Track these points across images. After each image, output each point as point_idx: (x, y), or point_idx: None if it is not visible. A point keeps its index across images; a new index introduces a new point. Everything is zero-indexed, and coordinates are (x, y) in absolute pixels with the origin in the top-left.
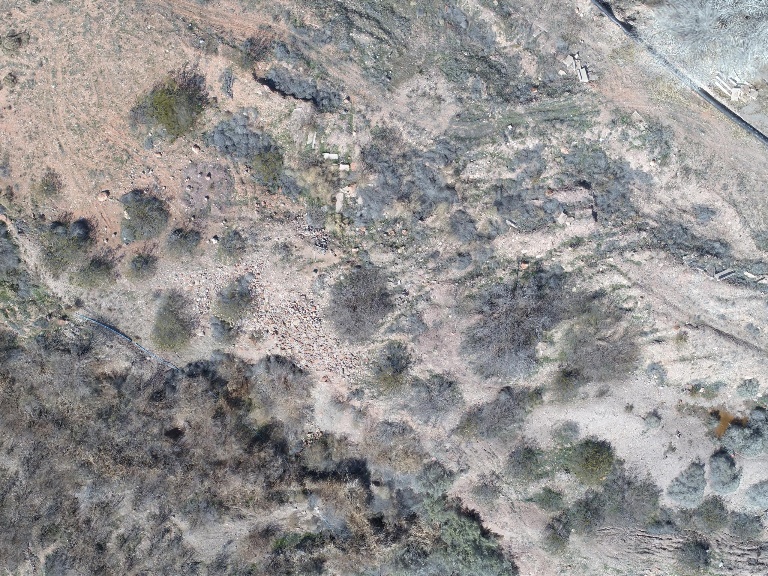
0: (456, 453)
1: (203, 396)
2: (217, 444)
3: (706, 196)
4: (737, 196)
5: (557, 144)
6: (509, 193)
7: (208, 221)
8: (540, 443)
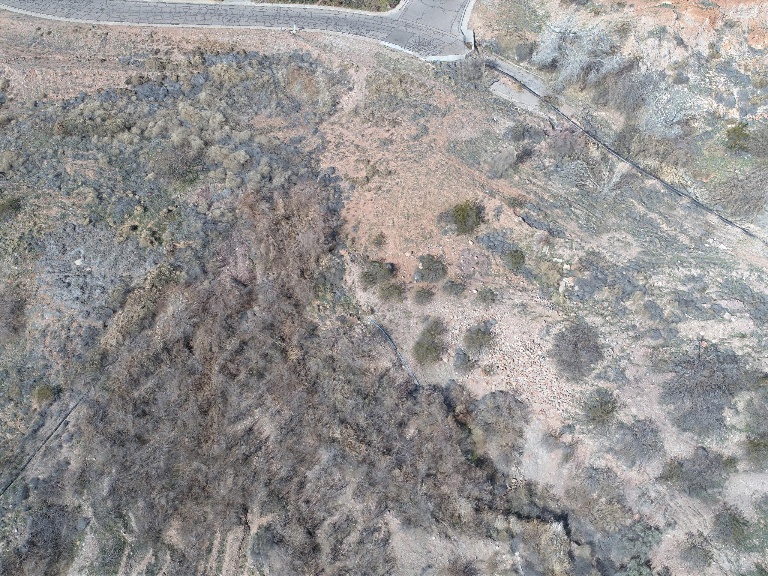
0: (661, 505)
1: (439, 405)
2: (446, 443)
3: None
4: None
5: (714, 275)
6: (684, 298)
7: (472, 281)
8: (743, 511)
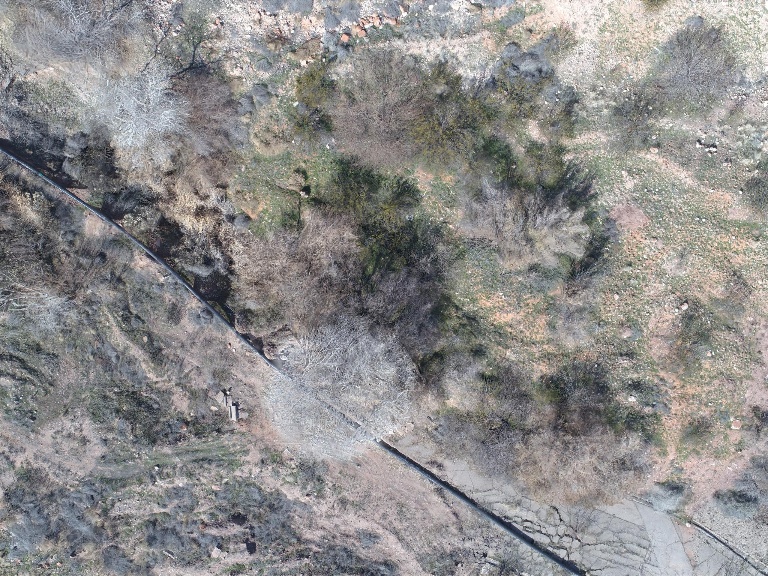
0: None
1: None
2: None
3: (366, 524)
4: (397, 524)
5: (207, 482)
6: (164, 526)
7: None
8: None
